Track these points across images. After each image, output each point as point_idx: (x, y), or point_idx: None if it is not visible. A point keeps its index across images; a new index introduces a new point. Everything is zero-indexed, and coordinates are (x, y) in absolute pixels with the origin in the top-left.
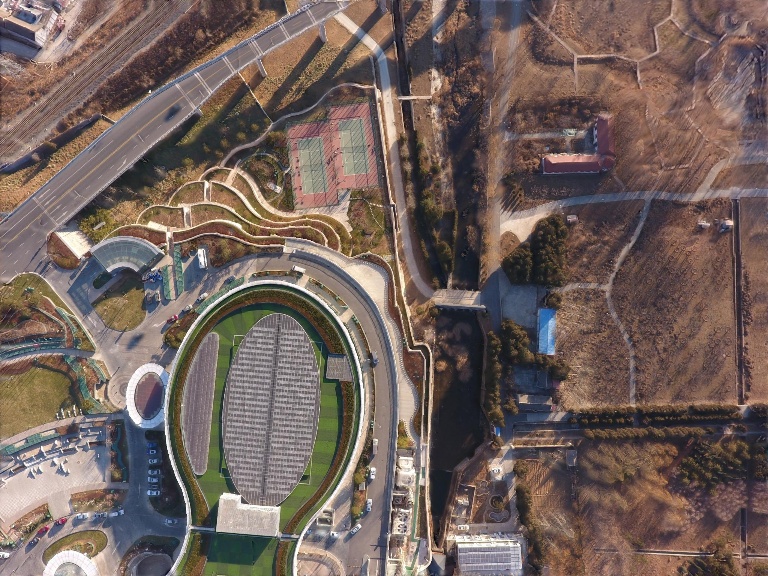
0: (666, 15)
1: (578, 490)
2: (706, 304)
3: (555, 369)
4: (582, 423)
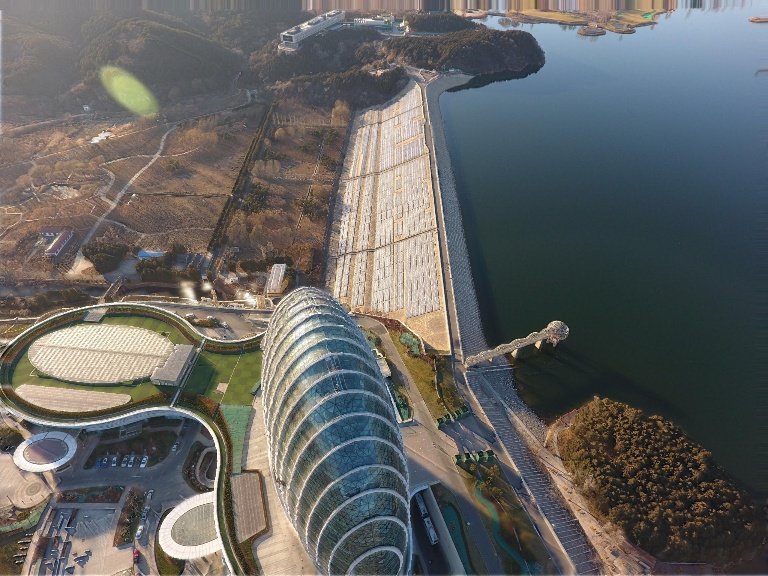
0: (3, 210)
1: (254, 248)
2: (173, 204)
3: (175, 250)
4: (216, 245)
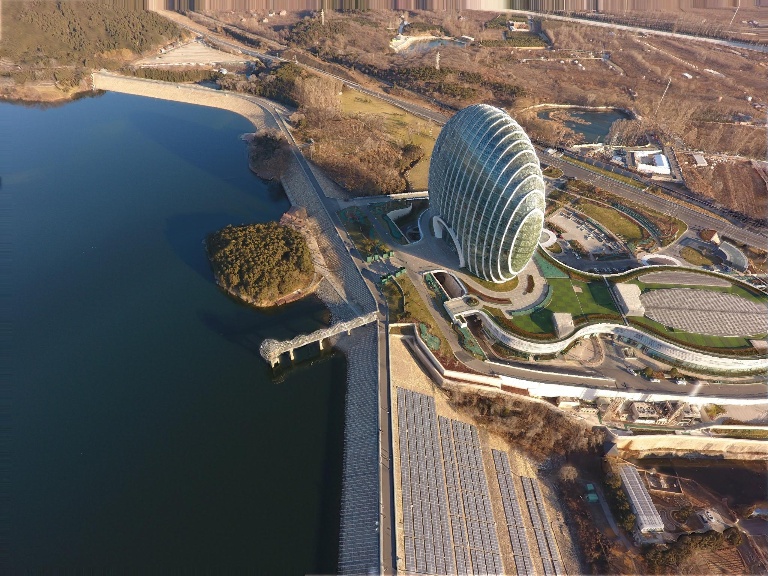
0: None
1: None
2: None
3: None
4: None
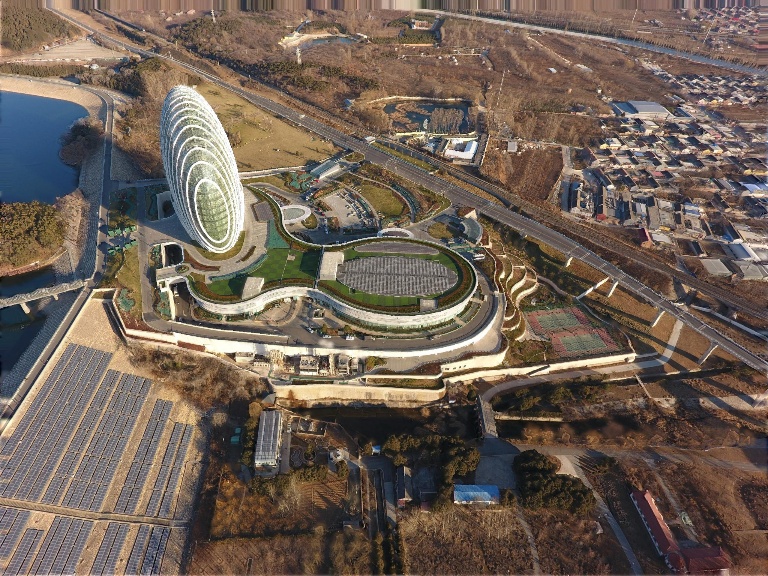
0: None
1: None
2: None
3: None
4: None
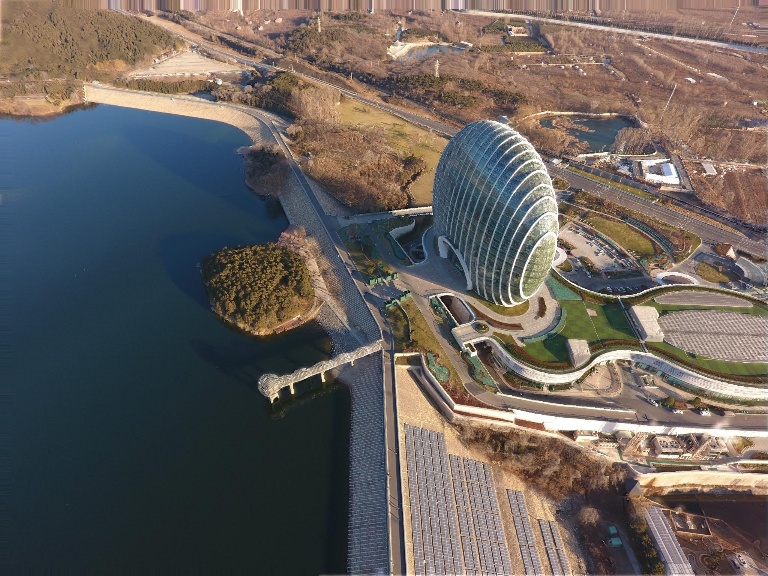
0: None
1: None
2: None
3: None
4: None
